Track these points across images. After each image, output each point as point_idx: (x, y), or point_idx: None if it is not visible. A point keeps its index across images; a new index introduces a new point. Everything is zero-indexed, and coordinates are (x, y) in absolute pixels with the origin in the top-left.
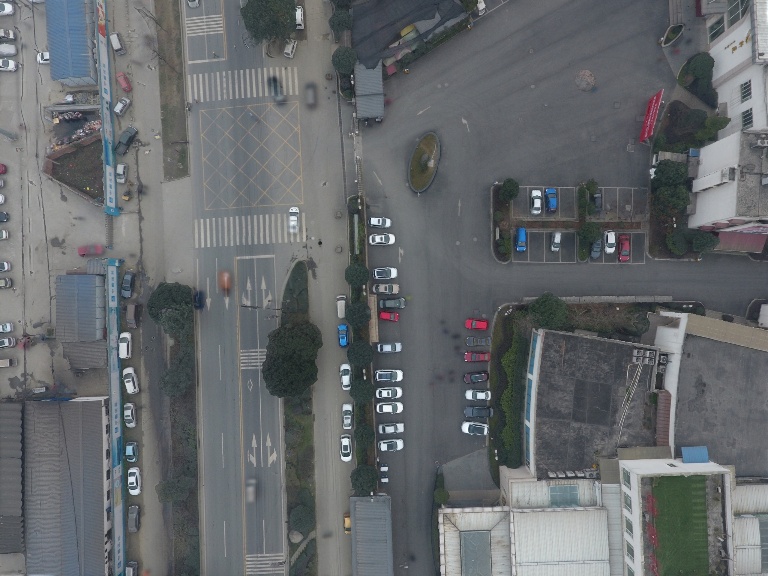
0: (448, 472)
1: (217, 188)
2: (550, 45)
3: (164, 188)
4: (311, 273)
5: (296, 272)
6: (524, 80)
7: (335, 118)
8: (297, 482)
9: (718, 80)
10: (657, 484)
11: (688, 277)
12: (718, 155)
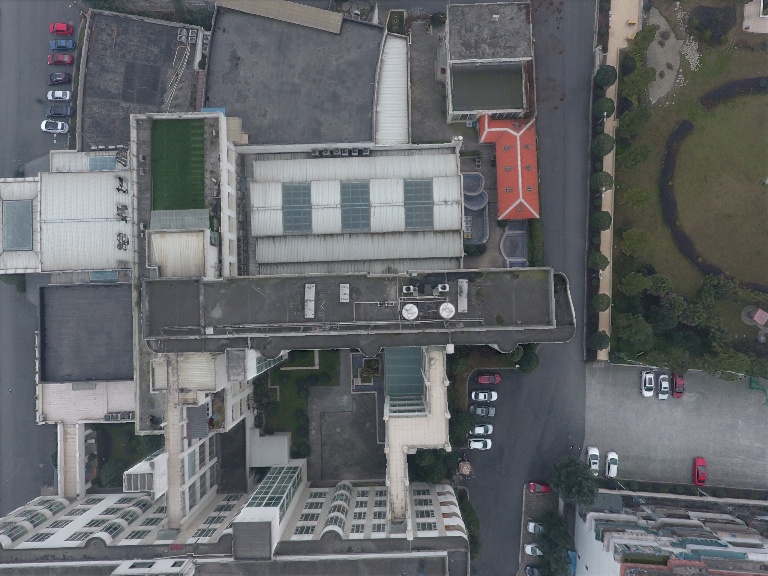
0: (29, 170)
1: None
2: None
3: None
4: None
5: None
6: None
7: None
8: None
9: None
10: (150, 125)
11: None
12: None
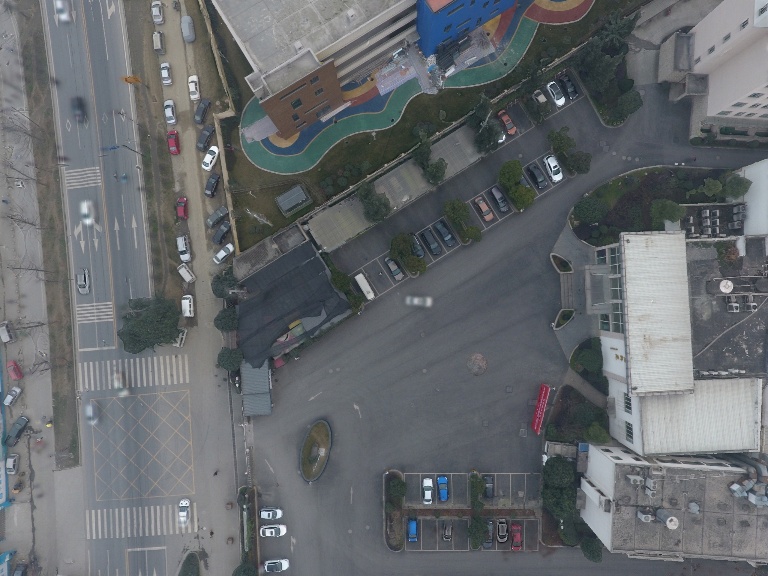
0: None
1: (108, 479)
2: (442, 328)
3: (56, 476)
4: (203, 564)
5: (186, 566)
6: (416, 364)
7: (226, 406)
8: None
9: (607, 373)
10: None
11: (582, 564)
12: (600, 468)
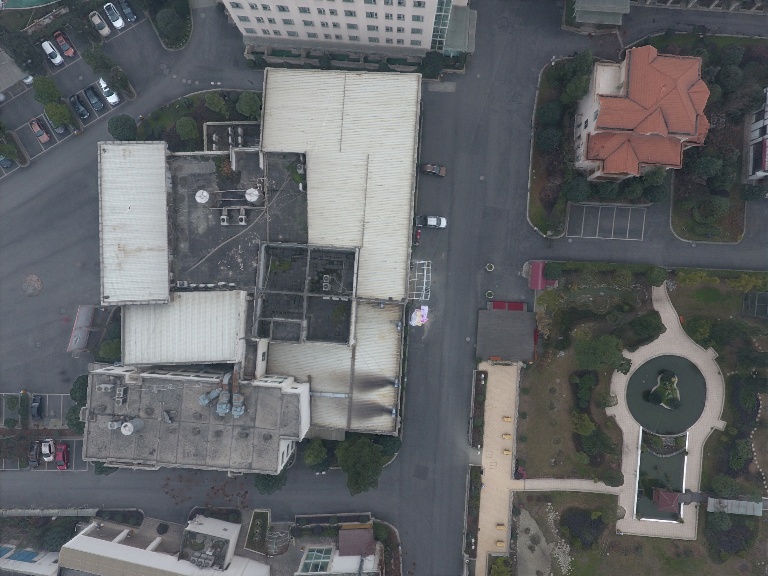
0: None
1: None
2: None
3: None
4: None
5: None
6: None
7: None
8: None
9: None
10: None
11: (130, 484)
12: None
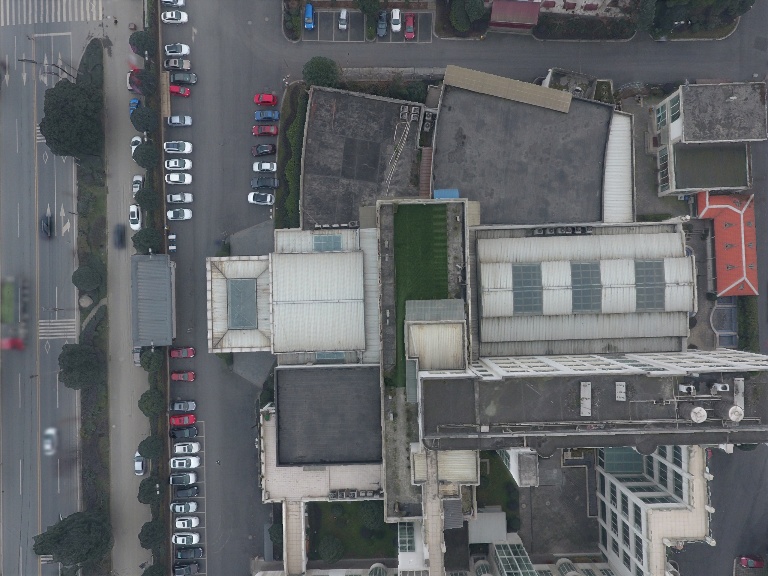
0: (235, 242)
1: None
2: None
3: None
4: (107, 51)
5: (90, 47)
6: None
7: None
8: (88, 249)
9: None
10: (396, 211)
11: (473, 56)
12: None
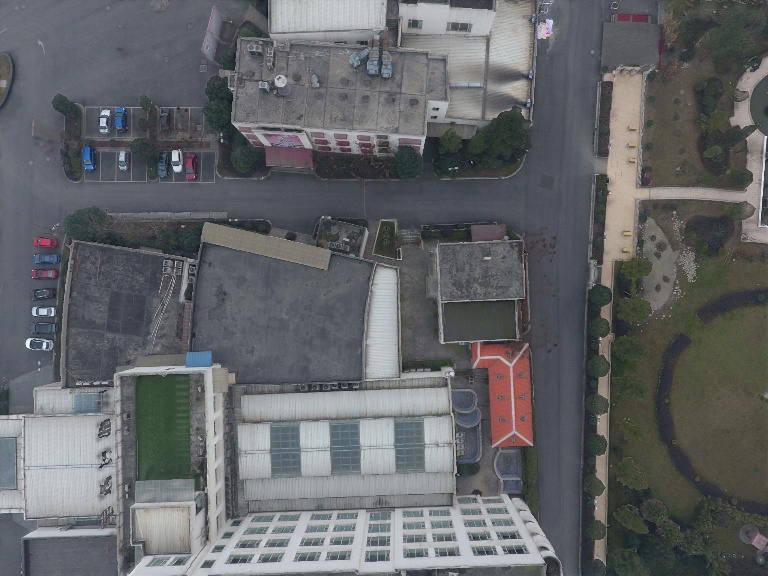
0: (14, 388)
1: None
2: None
3: None
4: None
5: None
6: (100, 2)
7: None
8: None
9: None
10: (135, 383)
11: (257, 196)
12: None
